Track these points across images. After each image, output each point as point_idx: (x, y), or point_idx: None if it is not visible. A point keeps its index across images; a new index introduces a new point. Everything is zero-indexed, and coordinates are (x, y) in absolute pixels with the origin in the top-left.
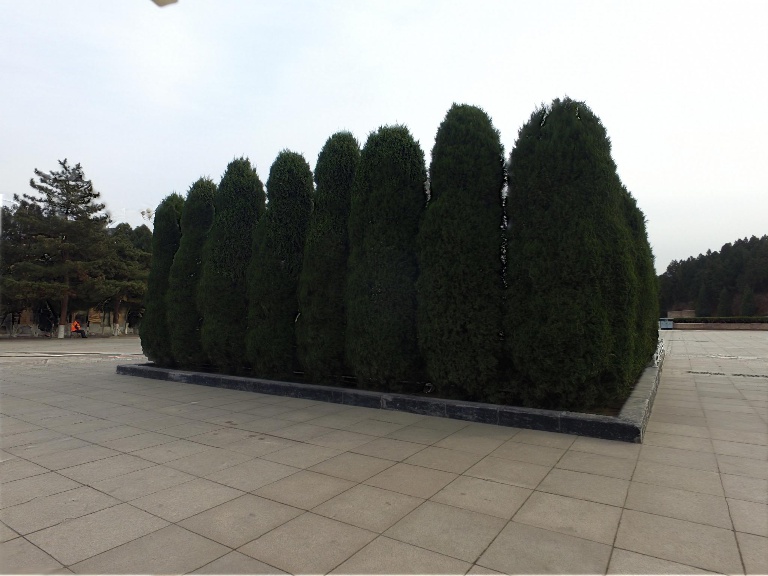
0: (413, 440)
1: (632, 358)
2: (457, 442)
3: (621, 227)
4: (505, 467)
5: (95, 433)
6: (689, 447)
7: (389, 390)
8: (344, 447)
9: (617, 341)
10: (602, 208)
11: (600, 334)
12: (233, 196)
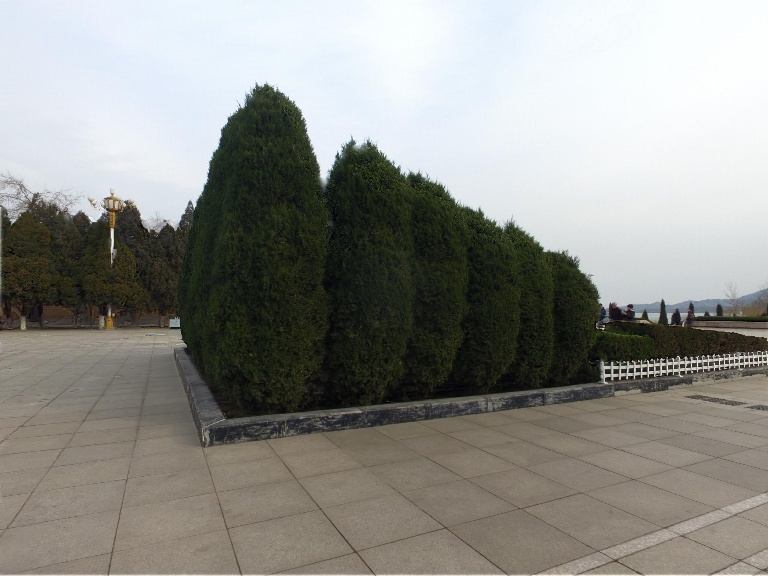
0: (91, 415)
1: (346, 362)
2: (107, 421)
3: (275, 216)
4: (43, 441)
5: (4, 387)
6: (219, 458)
7: (204, 378)
8: (45, 413)
9: (258, 340)
10: (248, 199)
11: (230, 332)
12: (198, 213)
